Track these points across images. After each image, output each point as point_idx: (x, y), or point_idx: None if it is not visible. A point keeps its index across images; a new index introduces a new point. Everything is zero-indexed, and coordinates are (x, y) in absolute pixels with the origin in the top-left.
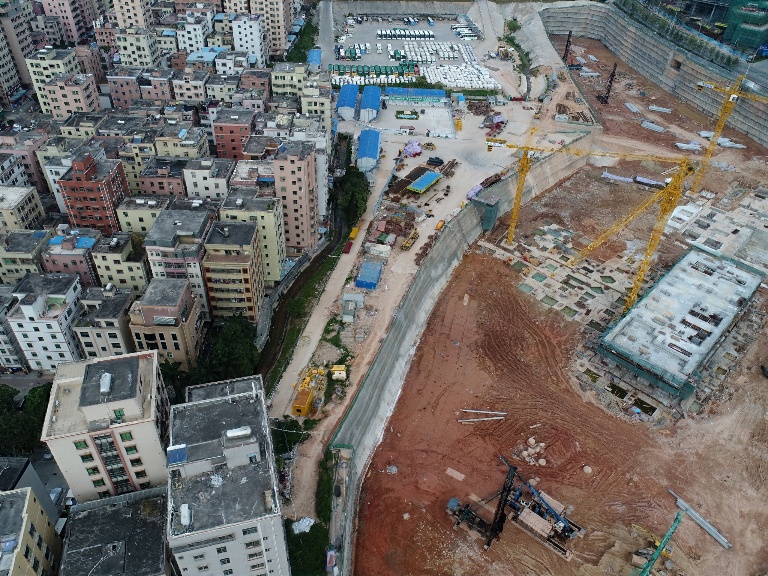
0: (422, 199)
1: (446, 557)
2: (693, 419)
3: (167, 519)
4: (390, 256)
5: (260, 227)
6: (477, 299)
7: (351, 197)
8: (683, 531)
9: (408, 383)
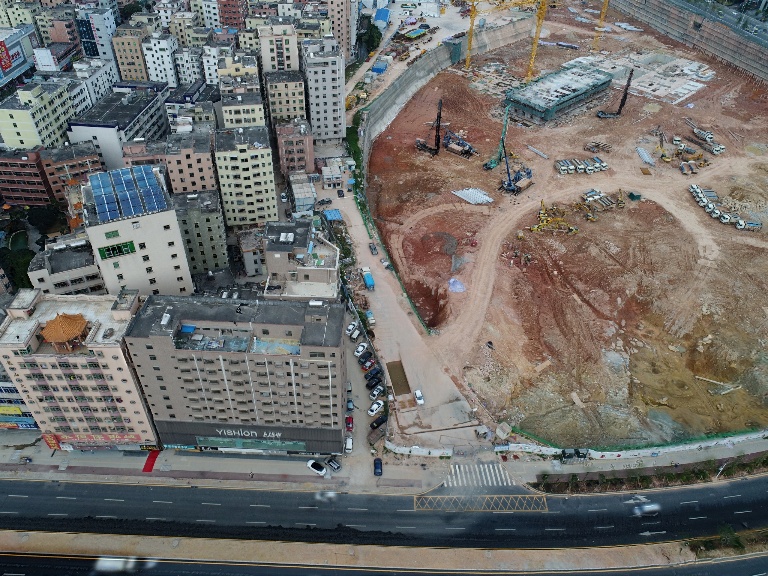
0: (414, 42)
1: (412, 159)
2: (550, 128)
3: None
4: (392, 63)
5: (321, 30)
6: (443, 89)
7: (370, 32)
8: (527, 154)
9: (400, 114)
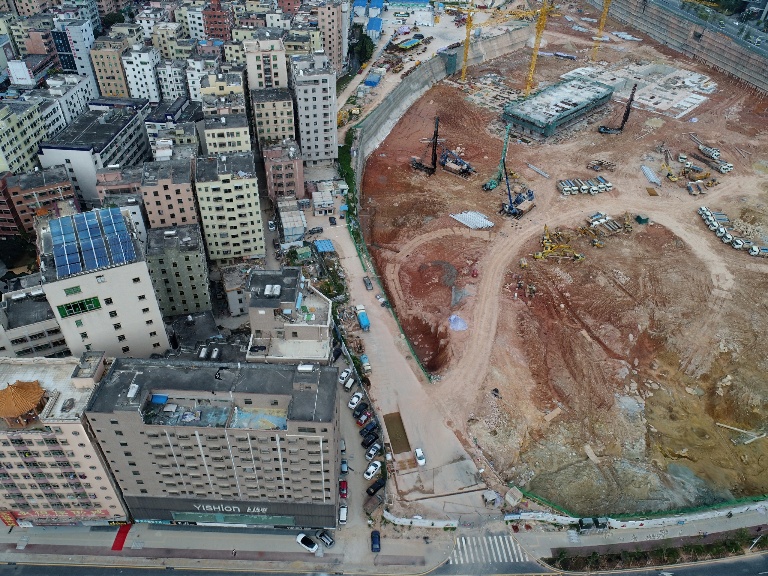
0: (408, 53)
1: (408, 179)
2: None
3: (295, 73)
4: (386, 75)
5: (311, 42)
6: (438, 102)
7: (362, 43)
8: (528, 174)
9: (394, 130)
